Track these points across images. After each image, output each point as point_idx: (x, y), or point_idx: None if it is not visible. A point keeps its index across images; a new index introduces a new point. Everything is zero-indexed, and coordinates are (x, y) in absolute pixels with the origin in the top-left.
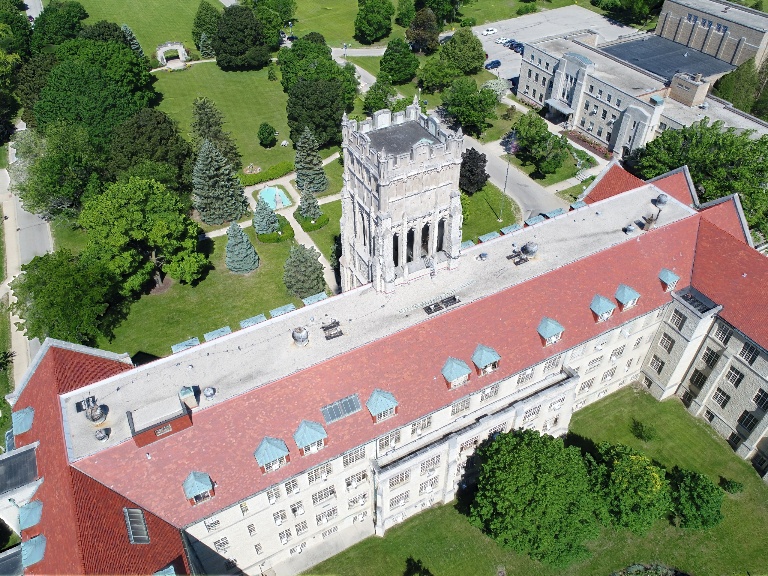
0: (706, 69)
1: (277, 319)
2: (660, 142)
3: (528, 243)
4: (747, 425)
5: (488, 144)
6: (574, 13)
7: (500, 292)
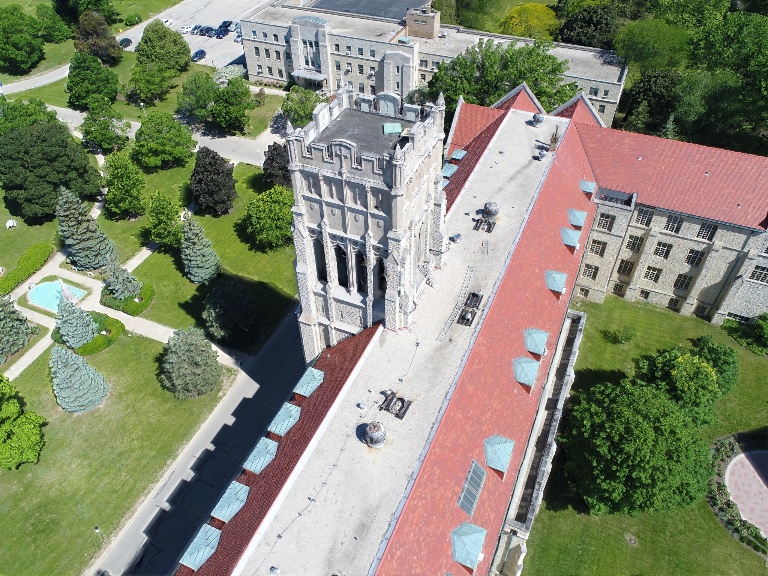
0: (410, 4)
1: (320, 432)
2: (443, 76)
3: (488, 205)
4: (683, 286)
5: (259, 137)
6: None
7: (509, 266)
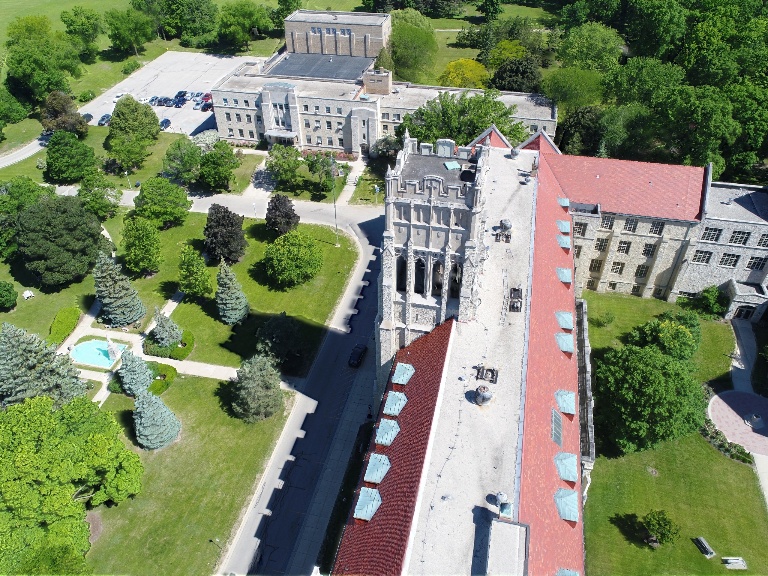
0: (356, 66)
1: (439, 401)
2: (409, 125)
3: (504, 221)
4: (642, 274)
5: (245, 193)
6: (177, 58)
7: (534, 265)
